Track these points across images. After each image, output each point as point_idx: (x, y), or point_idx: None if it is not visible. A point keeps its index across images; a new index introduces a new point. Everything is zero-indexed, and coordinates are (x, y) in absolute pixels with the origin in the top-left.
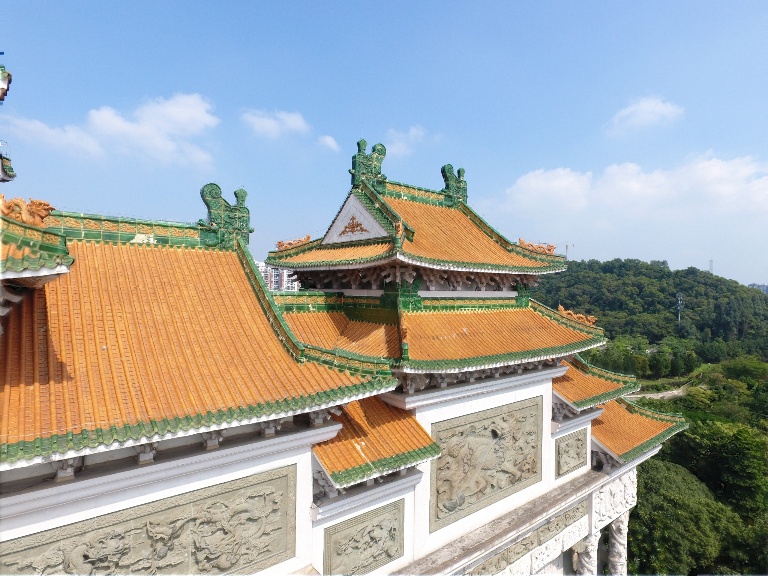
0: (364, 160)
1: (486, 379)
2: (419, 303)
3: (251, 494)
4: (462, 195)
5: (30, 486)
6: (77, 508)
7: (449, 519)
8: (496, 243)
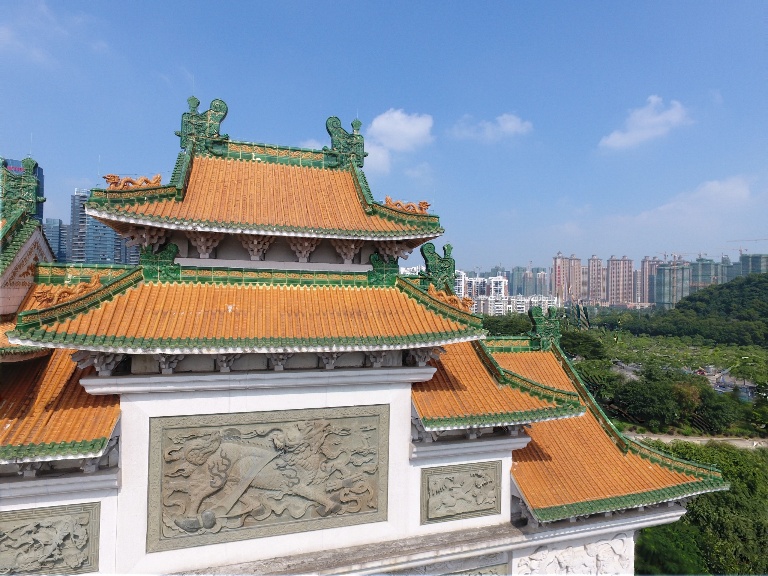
0: (194, 119)
1: (254, 371)
2: (175, 273)
3: None
4: (355, 153)
5: None
6: None
7: (187, 541)
8: (361, 205)
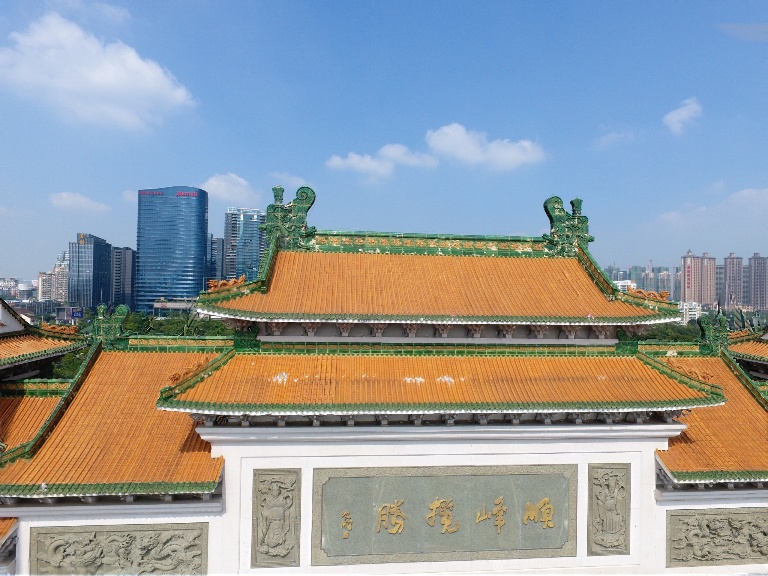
0: None
1: None
2: None
3: None
4: None
5: (689, 488)
6: (703, 502)
7: None
8: None
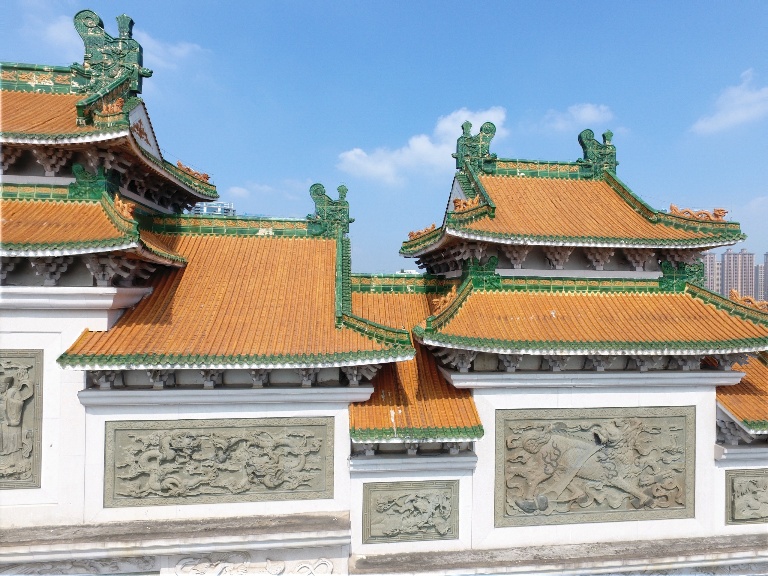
0: (469, 142)
1: (580, 371)
2: (497, 282)
3: (292, 433)
4: (608, 162)
5: (139, 388)
6: (167, 410)
7: (524, 520)
8: (638, 214)
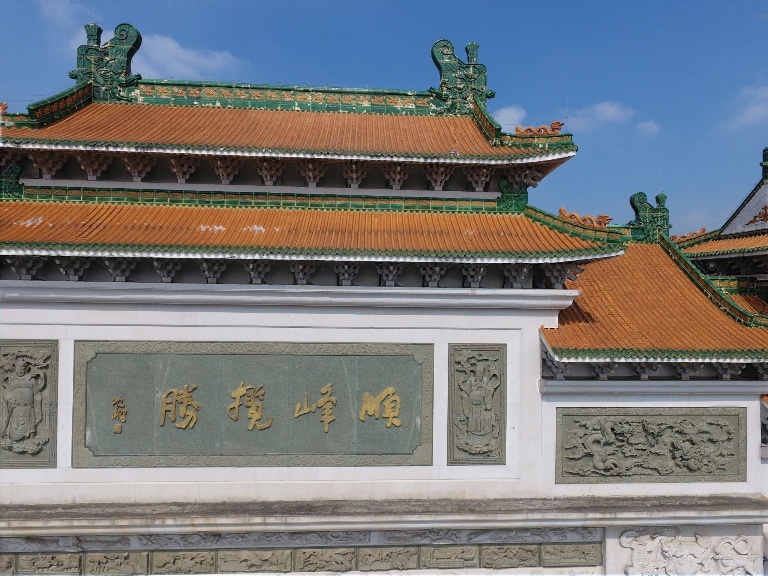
0: None
1: None
2: None
3: (711, 421)
4: None
5: (586, 379)
6: (607, 399)
7: None
8: None
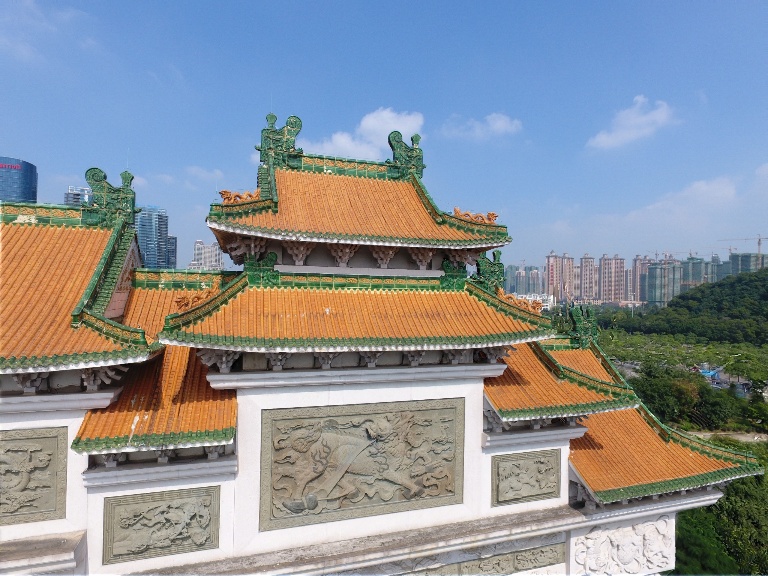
0: (272, 135)
1: (351, 368)
2: (275, 278)
3: (12, 448)
4: (415, 165)
5: None
6: None
7: (293, 521)
8: (429, 215)
